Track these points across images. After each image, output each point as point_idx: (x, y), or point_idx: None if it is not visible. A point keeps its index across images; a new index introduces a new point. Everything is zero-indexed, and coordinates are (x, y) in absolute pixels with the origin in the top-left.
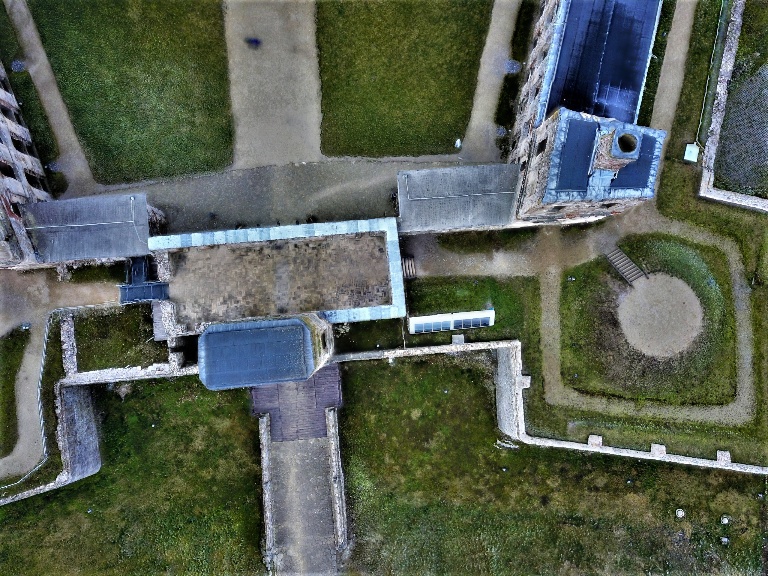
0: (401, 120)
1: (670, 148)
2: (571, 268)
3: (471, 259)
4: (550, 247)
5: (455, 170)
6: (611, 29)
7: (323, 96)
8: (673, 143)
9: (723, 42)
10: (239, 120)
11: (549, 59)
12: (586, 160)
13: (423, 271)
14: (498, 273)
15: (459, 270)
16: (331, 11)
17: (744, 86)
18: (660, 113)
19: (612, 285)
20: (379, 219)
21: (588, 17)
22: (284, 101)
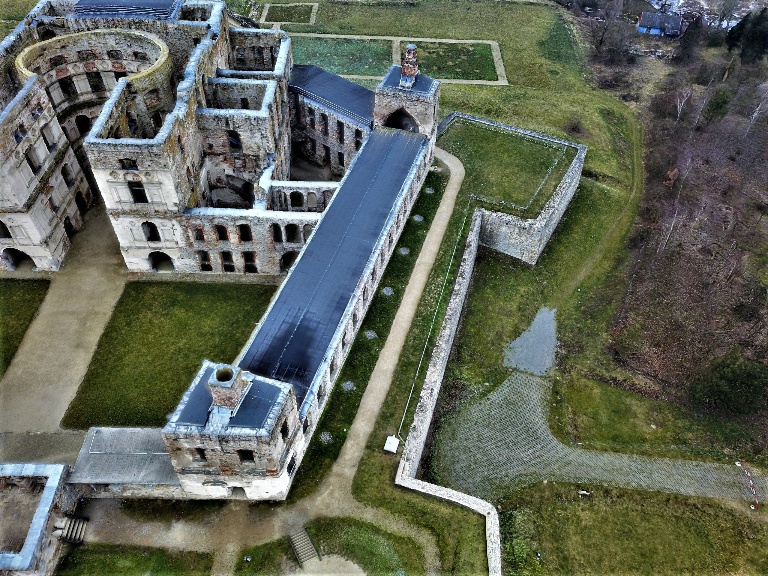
0: (144, 404)
1: (372, 439)
2: (251, 548)
3: (147, 528)
4: (234, 523)
5: (144, 430)
6: (299, 327)
7: (84, 381)
8: (375, 435)
9: (428, 360)
10: (0, 393)
11: (247, 346)
12: (210, 399)
13: (92, 537)
14: (170, 546)
15: (131, 539)
16: (120, 322)
17: (473, 407)
18: (366, 409)
19: (284, 567)
20: (47, 465)
21: (283, 319)
22: (48, 382)
